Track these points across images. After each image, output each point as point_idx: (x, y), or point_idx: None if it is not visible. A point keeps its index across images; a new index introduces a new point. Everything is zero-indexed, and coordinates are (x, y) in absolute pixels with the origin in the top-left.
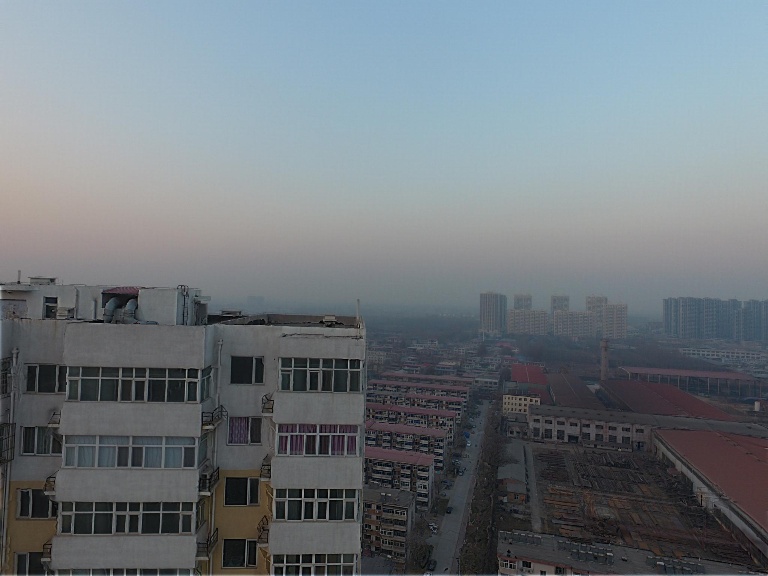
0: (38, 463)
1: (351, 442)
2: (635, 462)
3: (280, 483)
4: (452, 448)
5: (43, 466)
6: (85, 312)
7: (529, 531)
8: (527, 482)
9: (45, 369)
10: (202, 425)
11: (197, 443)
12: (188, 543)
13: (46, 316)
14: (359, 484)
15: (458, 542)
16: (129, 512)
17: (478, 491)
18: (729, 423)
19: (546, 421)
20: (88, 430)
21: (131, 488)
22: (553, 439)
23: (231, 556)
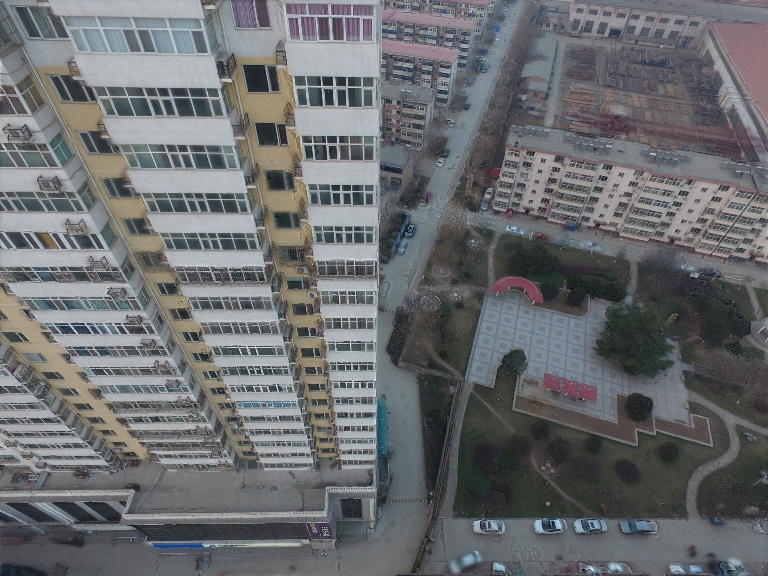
0: (51, 48)
1: (367, 26)
2: (672, 60)
3: (298, 70)
4: (479, 43)
5: (57, 51)
6: None
7: None
8: (551, 80)
9: None
10: (202, 4)
11: (203, 26)
12: (224, 125)
13: None
14: (377, 72)
15: (472, 135)
16: (160, 97)
17: None
18: None
19: (591, 11)
20: (83, 10)
21: (153, 74)
22: (592, 33)
23: (265, 137)
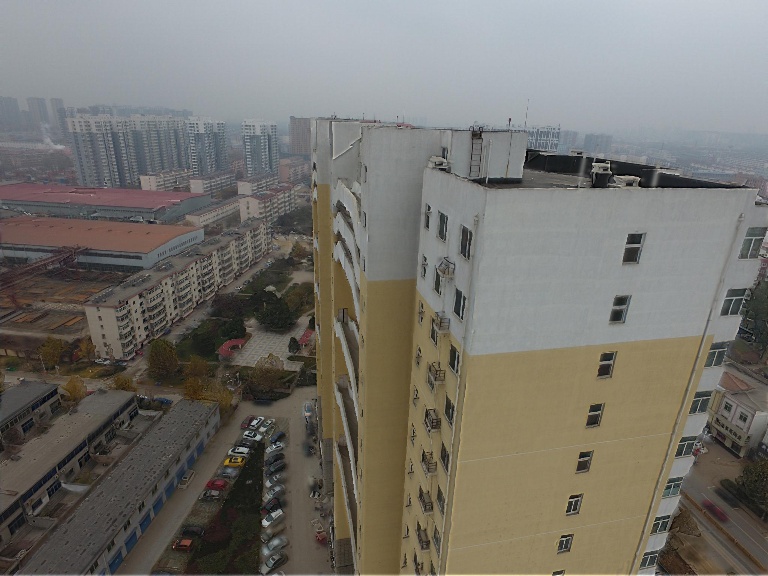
0: None
1: None
2: None
3: None
4: None
5: None
6: None
7: None
8: None
9: None
10: None
11: None
12: None
13: None
14: None
15: None
16: None
17: None
18: None
19: None
20: None
21: None
22: None
23: None
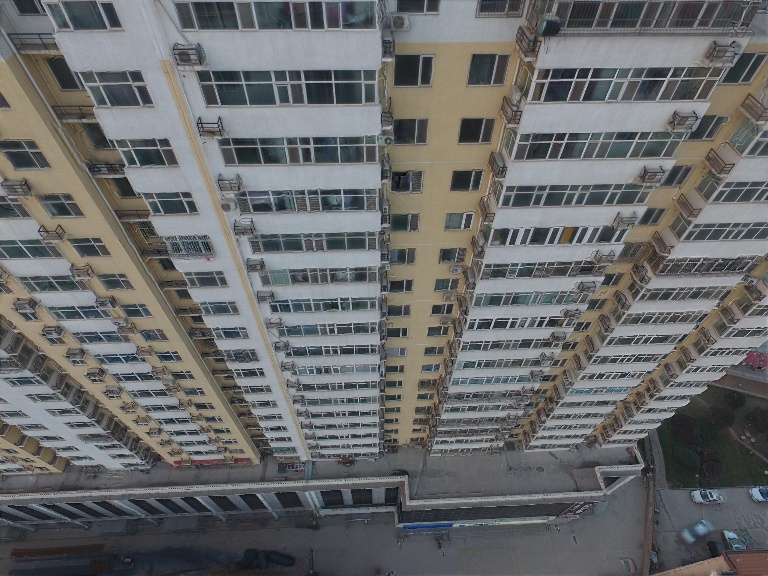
0: (766, 22)
1: None
2: None
3: None
4: None
5: None
6: None
7: None
8: None
9: None
10: None
11: None
12: None
13: None
14: None
15: None
16: None
17: None
18: None
19: None
20: None
21: None
22: None
23: None
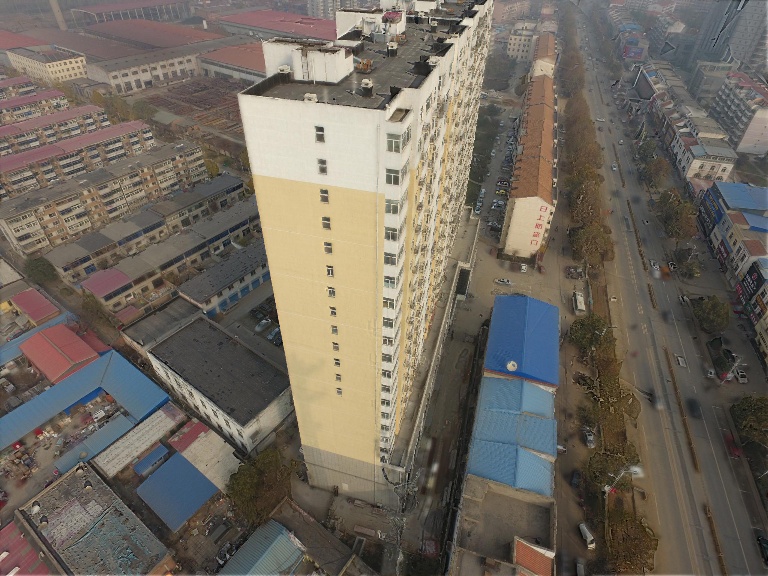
0: None
1: None
2: (205, 84)
3: None
4: None
5: None
6: None
7: None
8: None
9: None
10: None
11: None
12: None
13: None
14: None
15: None
16: None
17: (162, 139)
18: (228, 38)
19: (123, 75)
20: None
21: None
22: (134, 90)
23: None
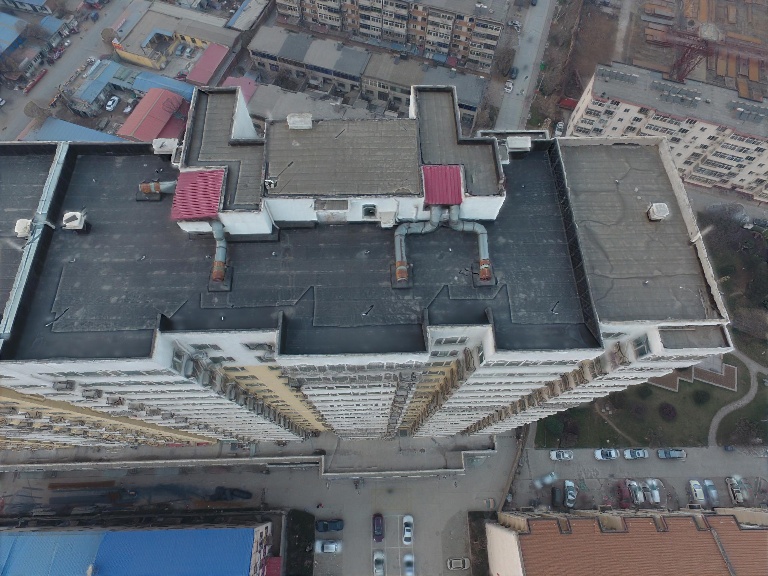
0: None
1: None
2: None
3: None
4: None
5: None
6: (405, 213)
7: (627, 65)
8: None
9: (449, 338)
10: None
11: None
12: None
13: (365, 215)
14: None
15: (540, 45)
16: None
17: None
18: None
19: None
20: None
21: None
22: None
23: None
